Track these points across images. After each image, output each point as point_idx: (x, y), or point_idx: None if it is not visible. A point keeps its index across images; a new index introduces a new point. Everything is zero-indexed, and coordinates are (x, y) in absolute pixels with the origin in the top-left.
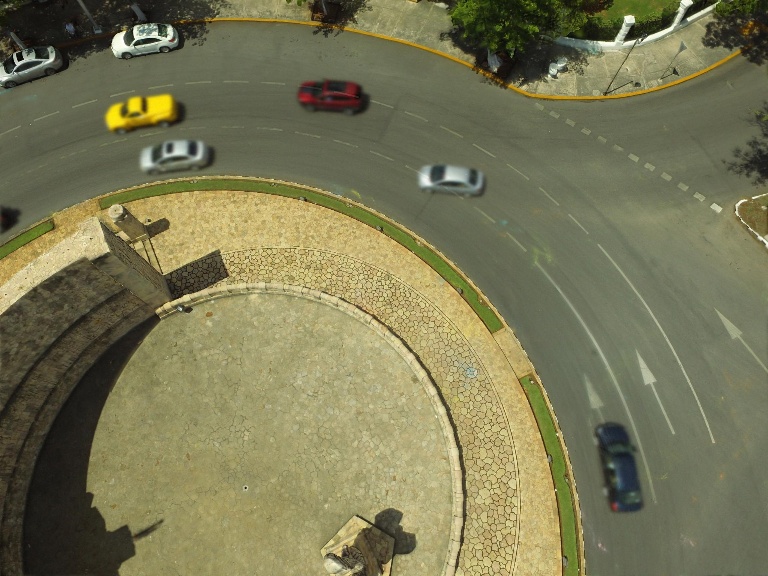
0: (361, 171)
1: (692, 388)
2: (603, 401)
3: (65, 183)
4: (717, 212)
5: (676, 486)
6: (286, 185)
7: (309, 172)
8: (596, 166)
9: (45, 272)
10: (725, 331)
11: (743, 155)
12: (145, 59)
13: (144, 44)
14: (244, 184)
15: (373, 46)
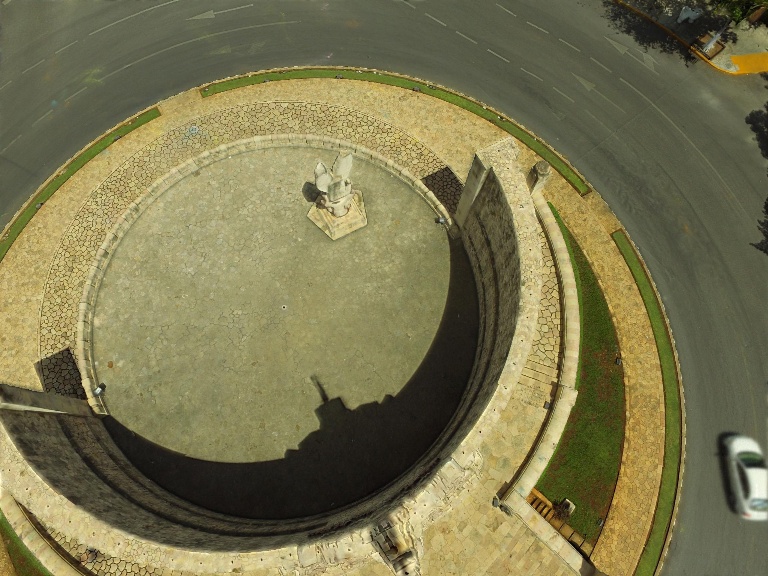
0: None
1: None
2: (226, 45)
3: None
4: None
5: (289, 8)
6: None
7: None
8: (9, 29)
9: (6, 450)
10: None
11: None
12: None
13: None
14: None
15: None
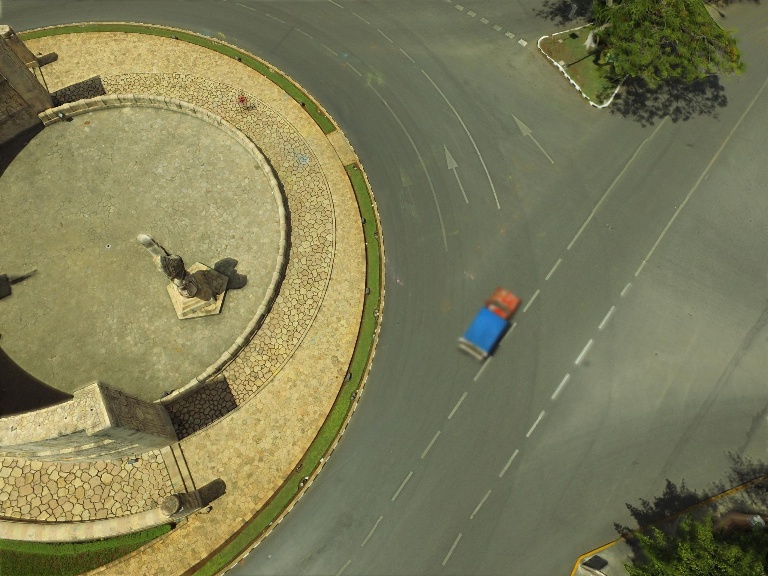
0: (227, 18)
1: (486, 171)
2: (413, 181)
3: None
4: (523, 46)
5: (465, 239)
6: (162, 29)
7: (183, 19)
8: (427, 14)
9: None
10: (518, 130)
11: (550, 4)
12: None
13: None
14: (125, 28)
15: None
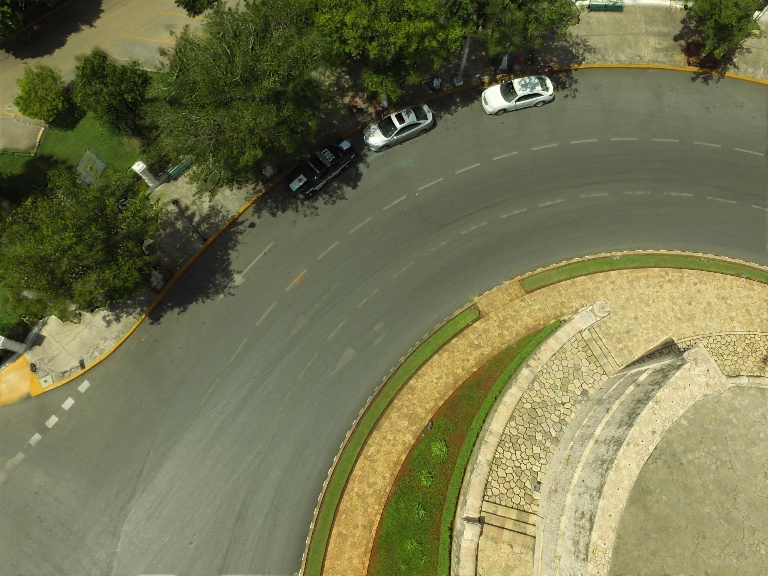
0: None
1: None
2: None
3: (476, 262)
4: None
5: None
6: (717, 260)
7: (737, 244)
8: None
9: (673, 412)
10: None
11: None
12: (518, 115)
13: (525, 100)
14: (672, 260)
15: (762, 94)
